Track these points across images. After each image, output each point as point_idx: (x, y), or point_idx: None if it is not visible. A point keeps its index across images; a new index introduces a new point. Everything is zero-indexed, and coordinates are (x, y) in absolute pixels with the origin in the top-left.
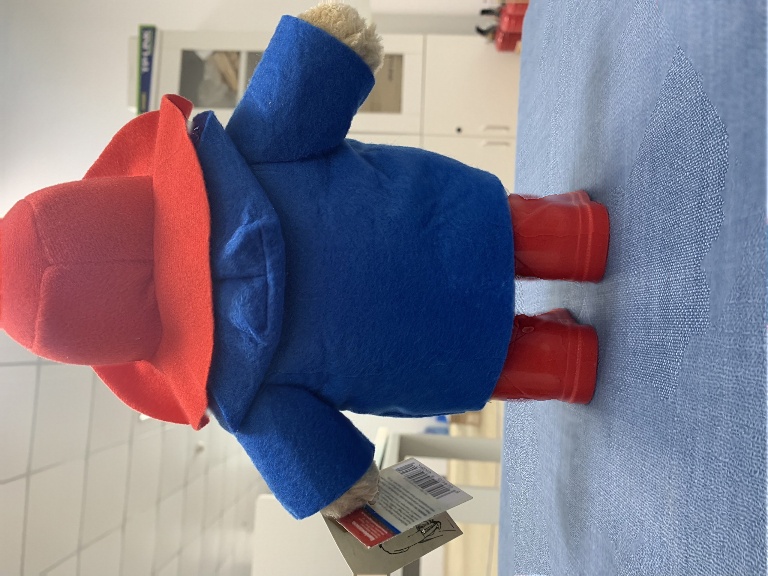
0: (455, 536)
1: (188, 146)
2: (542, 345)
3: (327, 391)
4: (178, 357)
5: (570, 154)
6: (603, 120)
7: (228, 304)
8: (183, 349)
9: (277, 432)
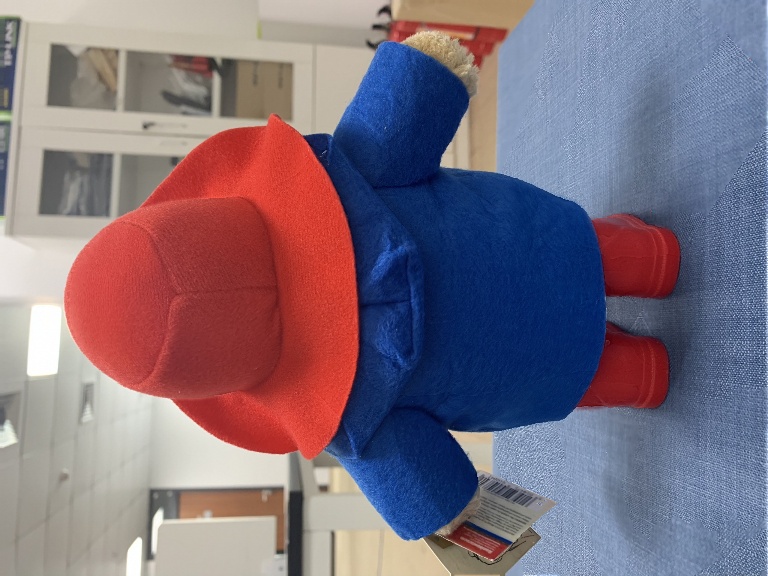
0: (536, 541)
1: (319, 170)
2: (620, 357)
3: (442, 411)
4: (300, 385)
5: (603, 180)
6: (663, 153)
7: (373, 330)
8: (309, 377)
9: (401, 455)
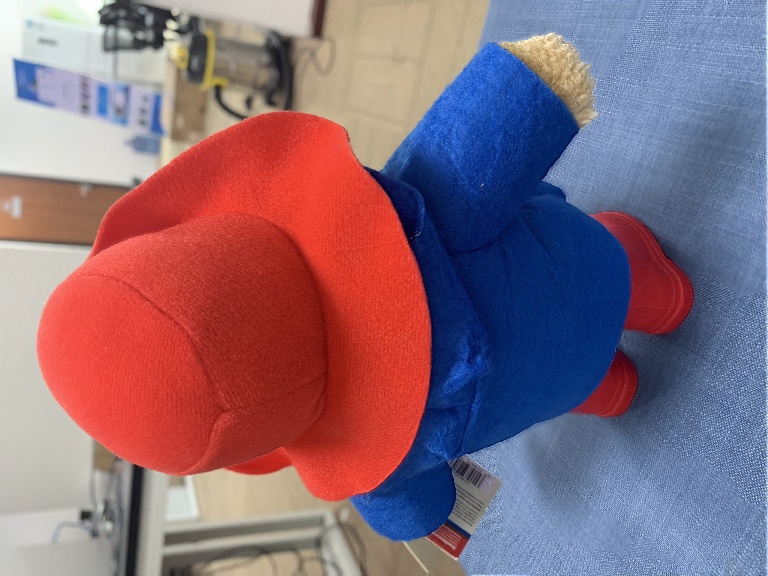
0: None
1: (410, 261)
2: None
3: None
4: (328, 454)
5: (626, 166)
6: (715, 199)
7: (429, 434)
8: (342, 452)
9: (405, 496)
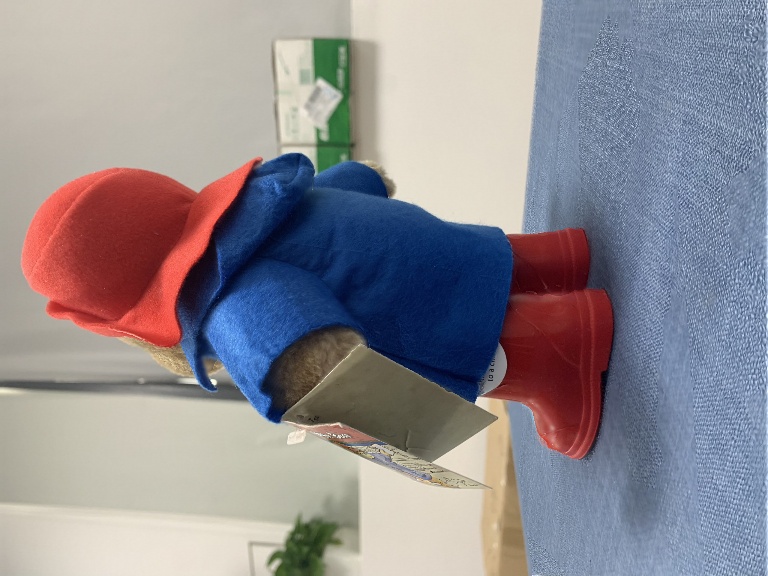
0: None
1: None
2: None
3: (328, 275)
4: (189, 239)
5: None
6: (560, 218)
7: (260, 178)
8: None
9: (269, 278)
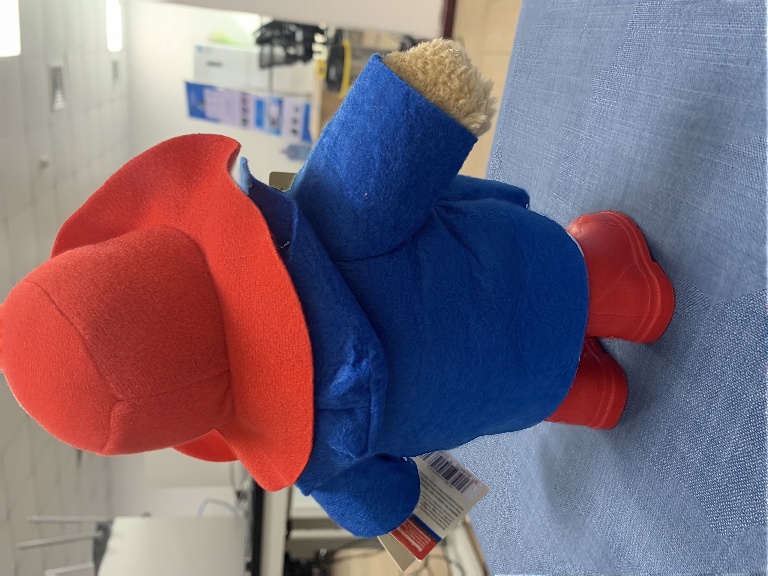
0: None
1: (279, 269)
2: (581, 393)
3: (394, 453)
4: (253, 446)
5: (623, 162)
6: (695, 196)
7: (328, 433)
8: (262, 445)
9: (348, 493)
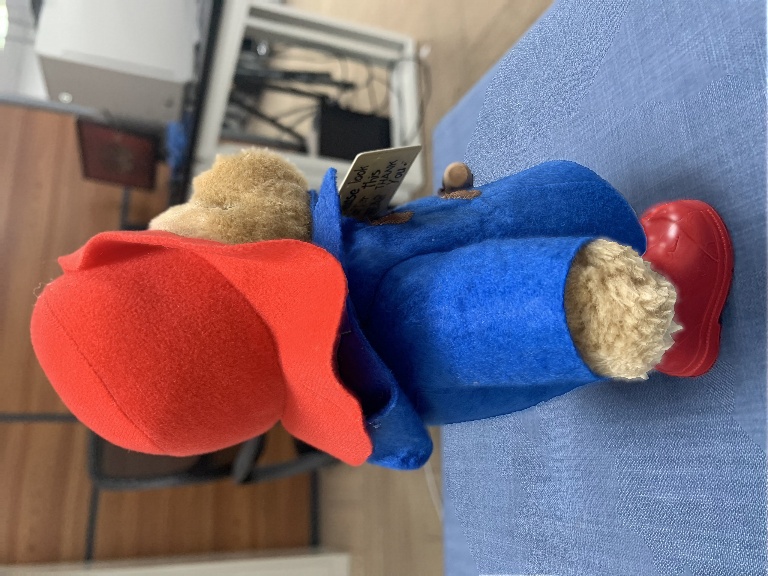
0: None
1: (362, 436)
2: None
3: None
4: None
5: None
6: None
7: None
8: None
9: None
